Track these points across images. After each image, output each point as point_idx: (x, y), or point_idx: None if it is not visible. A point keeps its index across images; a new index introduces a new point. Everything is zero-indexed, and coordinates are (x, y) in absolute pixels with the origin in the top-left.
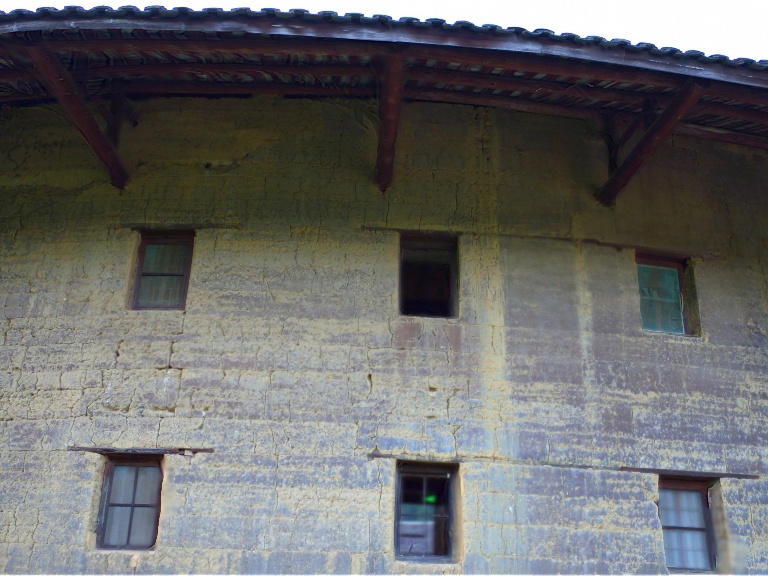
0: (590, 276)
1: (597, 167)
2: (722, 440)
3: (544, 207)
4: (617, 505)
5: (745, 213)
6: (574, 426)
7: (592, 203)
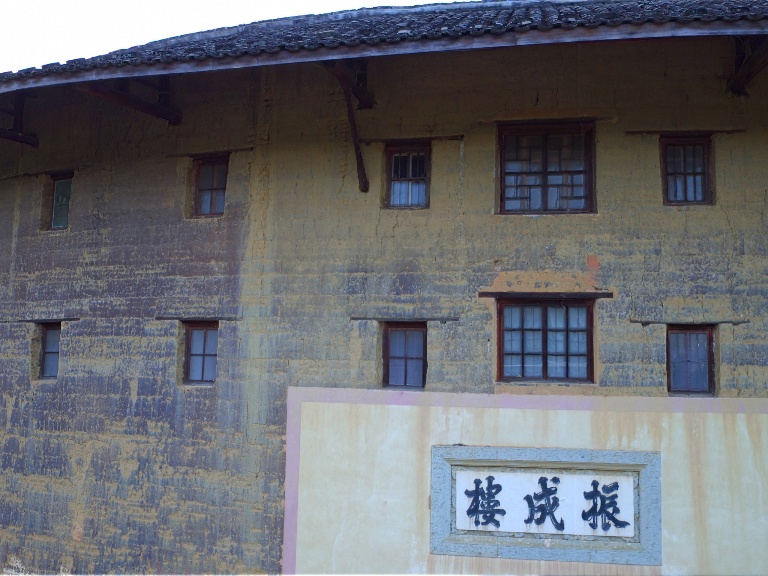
0: (21, 200)
1: (33, 119)
2: (65, 297)
3: (9, 157)
4: (14, 343)
5: (111, 124)
6: (4, 298)
7: (28, 147)
